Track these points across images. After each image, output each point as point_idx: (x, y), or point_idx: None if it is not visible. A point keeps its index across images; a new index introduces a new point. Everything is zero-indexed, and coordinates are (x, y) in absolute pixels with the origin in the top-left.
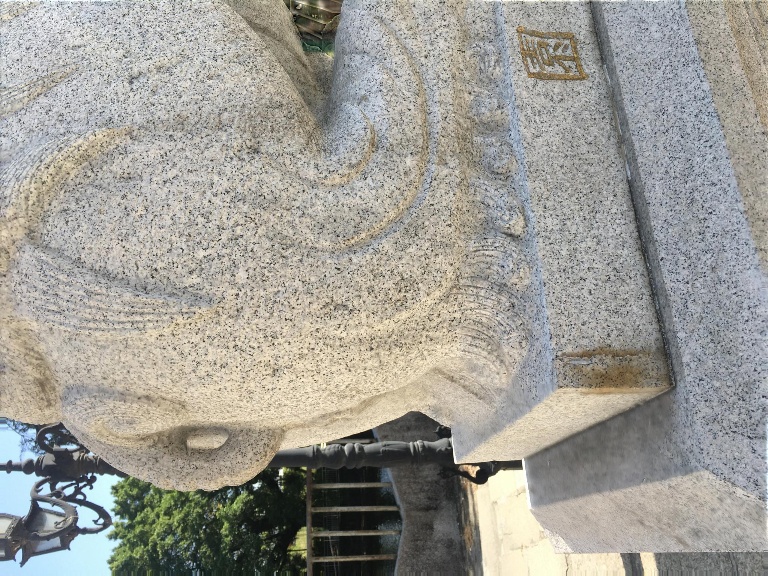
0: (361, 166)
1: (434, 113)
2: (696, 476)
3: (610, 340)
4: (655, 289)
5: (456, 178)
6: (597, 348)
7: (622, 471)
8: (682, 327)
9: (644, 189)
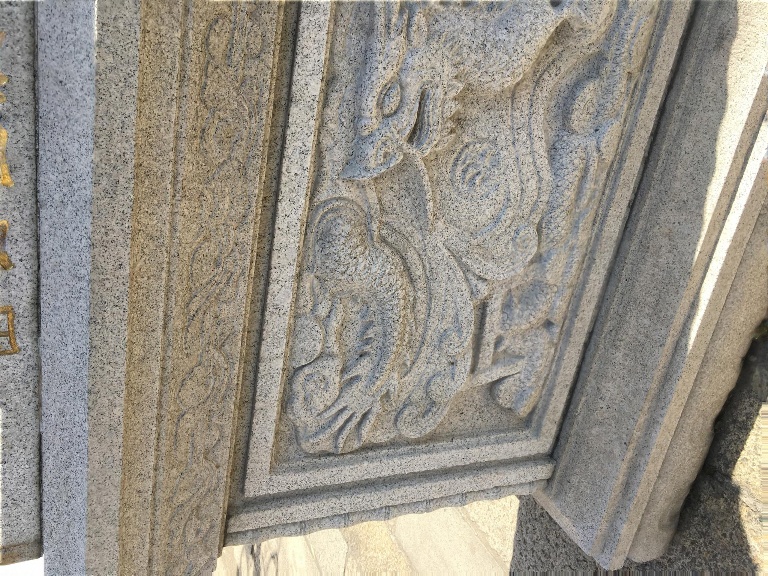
0: None
1: None
2: None
3: None
4: None
5: None
6: None
7: None
8: (47, 542)
9: (43, 456)
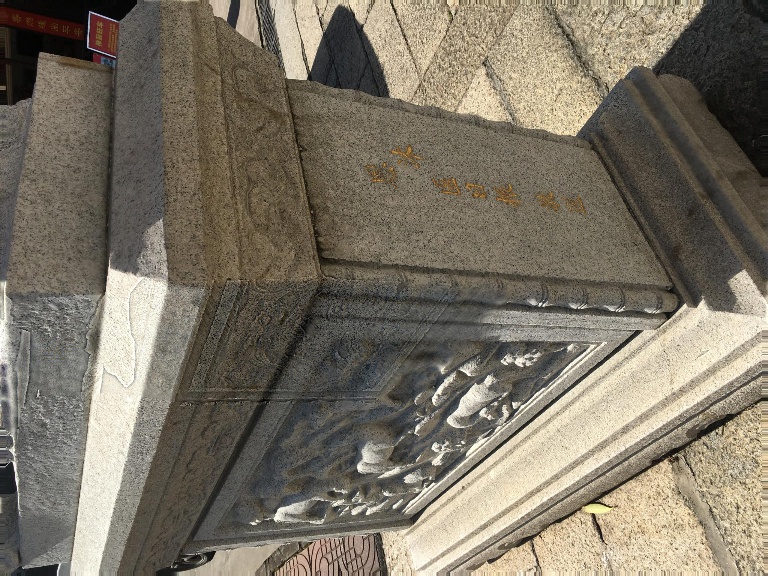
0: None
1: None
2: (121, 27)
3: None
4: None
5: None
6: None
7: (115, 91)
8: None
9: None
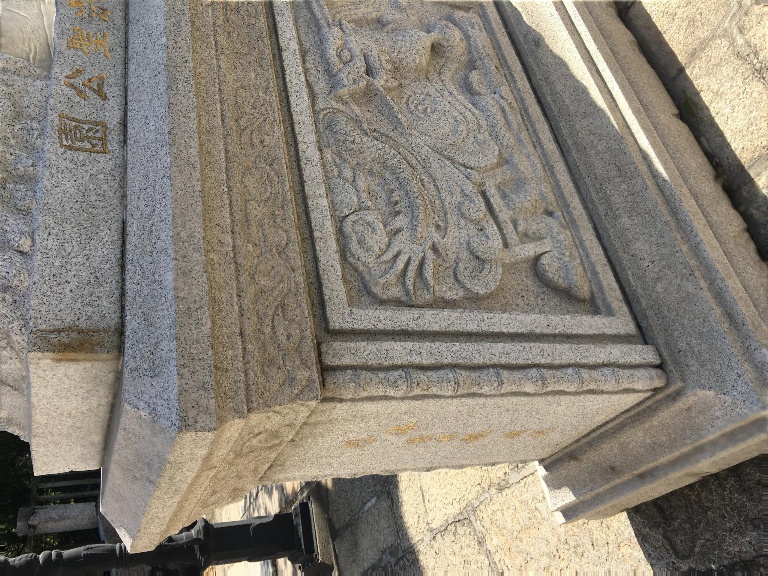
0: None
1: None
2: (125, 411)
3: (79, 322)
4: (124, 291)
5: None
6: (67, 327)
7: None
8: (130, 312)
9: (127, 225)
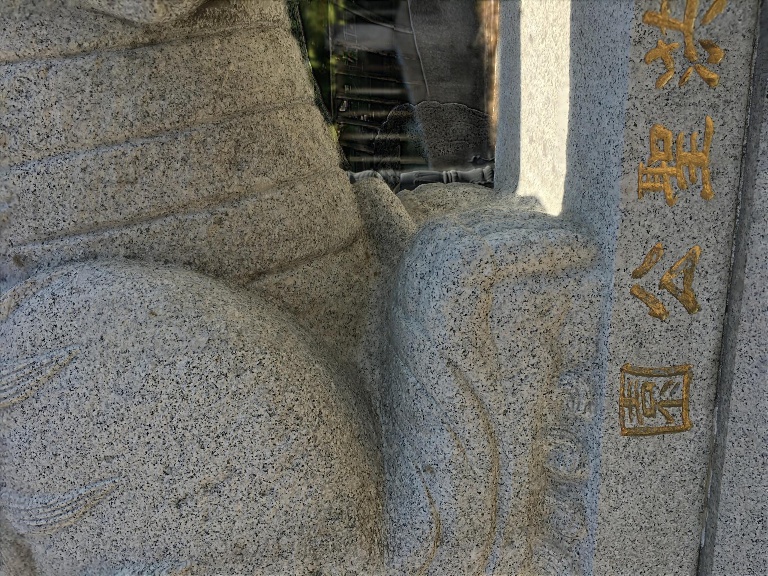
0: (424, 567)
1: (506, 487)
2: None
3: None
4: None
5: (520, 557)
6: None
7: None
8: None
9: None
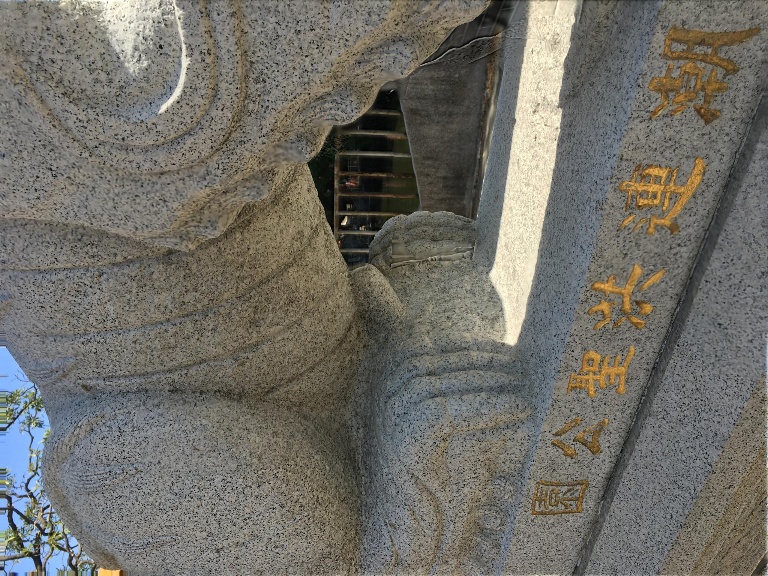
0: None
1: (446, 537)
2: None
3: None
4: None
5: (452, 569)
6: None
7: None
8: None
9: None
